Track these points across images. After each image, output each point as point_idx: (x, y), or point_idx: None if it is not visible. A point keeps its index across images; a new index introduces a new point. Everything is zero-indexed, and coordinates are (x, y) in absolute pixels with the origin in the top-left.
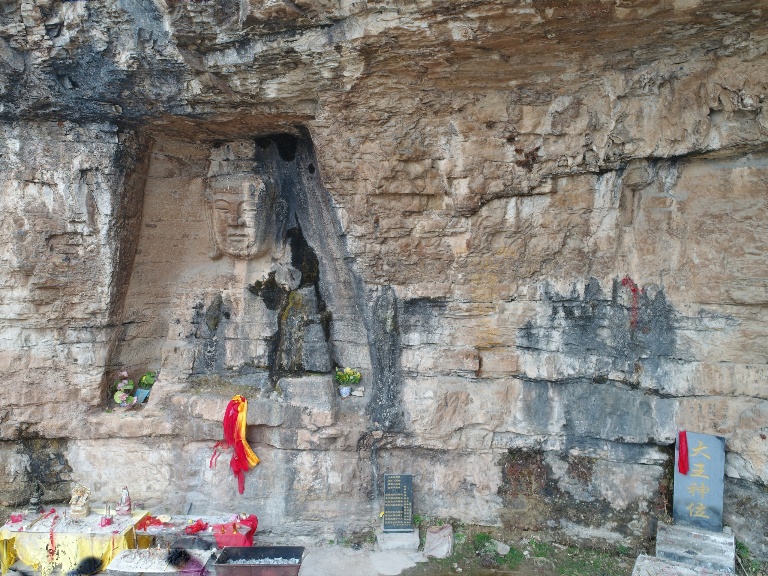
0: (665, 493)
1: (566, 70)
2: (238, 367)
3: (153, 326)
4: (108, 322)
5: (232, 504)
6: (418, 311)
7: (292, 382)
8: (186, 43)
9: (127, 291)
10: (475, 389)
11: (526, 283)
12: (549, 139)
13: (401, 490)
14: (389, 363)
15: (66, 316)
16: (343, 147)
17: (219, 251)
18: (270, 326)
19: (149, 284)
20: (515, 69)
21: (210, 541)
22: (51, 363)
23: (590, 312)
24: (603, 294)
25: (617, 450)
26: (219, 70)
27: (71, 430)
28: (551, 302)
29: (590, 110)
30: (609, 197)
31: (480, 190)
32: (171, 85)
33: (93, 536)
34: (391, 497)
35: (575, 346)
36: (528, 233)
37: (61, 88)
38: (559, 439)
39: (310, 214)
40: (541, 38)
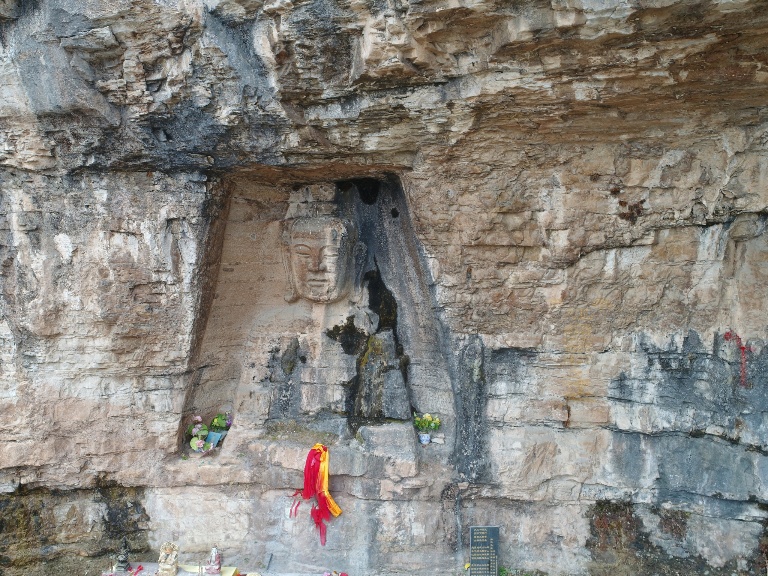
0: (766, 552)
1: (683, 126)
2: (314, 412)
3: (225, 368)
4: (187, 369)
5: (314, 555)
6: (504, 359)
7: (375, 431)
8: (290, 98)
9: (203, 336)
10: (562, 439)
11: (621, 334)
12: (655, 192)
13: (487, 543)
14: (475, 413)
15: (146, 364)
16: (441, 199)
17: (296, 294)
18: (348, 371)
19: (224, 327)
20: (630, 125)
21: None
22: (129, 411)
23: (688, 365)
24: (703, 347)
25: (713, 505)
26: (320, 124)
27: (149, 479)
28: (647, 354)
29: (704, 165)
30: (714, 250)
31: (580, 242)
32: (268, 138)
33: None
34: (477, 550)
35: (671, 399)
36: (625, 284)
37: (155, 141)
38: (651, 492)
39: (390, 258)
40: (668, 98)
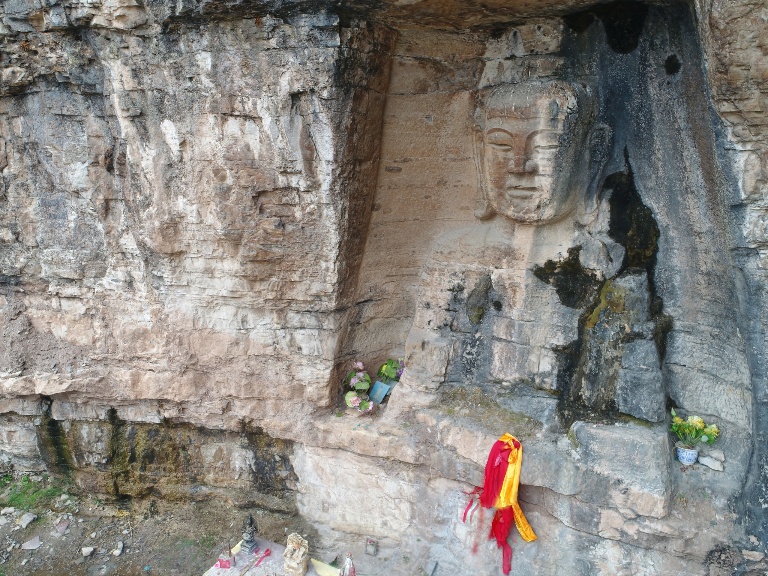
0: None
1: None
2: (510, 383)
3: (396, 304)
4: (336, 307)
5: None
6: None
7: (598, 435)
8: None
9: (361, 262)
10: None
11: None
12: None
13: None
14: None
15: (285, 297)
16: None
17: (491, 208)
18: (564, 331)
19: (391, 250)
20: None
21: None
22: (272, 350)
23: None
24: None
25: None
26: None
27: (296, 434)
28: None
29: None
30: None
31: None
32: None
33: None
34: None
35: None
36: None
37: None
38: None
39: (655, 150)
40: None
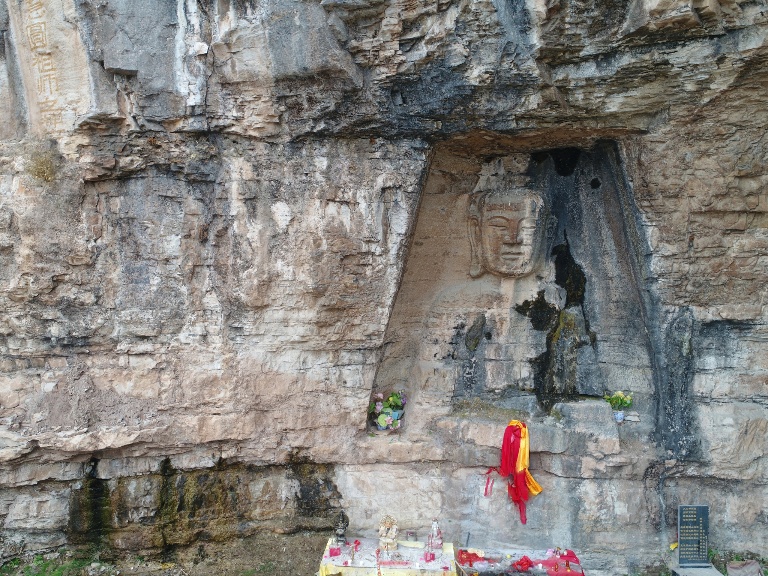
0: None
1: None
2: (500, 390)
3: (402, 346)
4: None
5: (514, 534)
6: (712, 333)
7: (575, 407)
8: (545, 56)
9: None
10: None
11: None
12: None
13: (697, 522)
14: (682, 388)
15: (345, 338)
16: (676, 163)
17: (482, 269)
18: (536, 347)
19: (407, 303)
20: None
21: (513, 575)
22: (323, 386)
23: None
24: None
25: None
26: (566, 84)
27: (342, 455)
28: None
29: None
30: None
31: None
32: (509, 100)
33: (423, 572)
34: (686, 530)
35: None
36: None
37: (391, 104)
38: None
39: (583, 231)
40: None
